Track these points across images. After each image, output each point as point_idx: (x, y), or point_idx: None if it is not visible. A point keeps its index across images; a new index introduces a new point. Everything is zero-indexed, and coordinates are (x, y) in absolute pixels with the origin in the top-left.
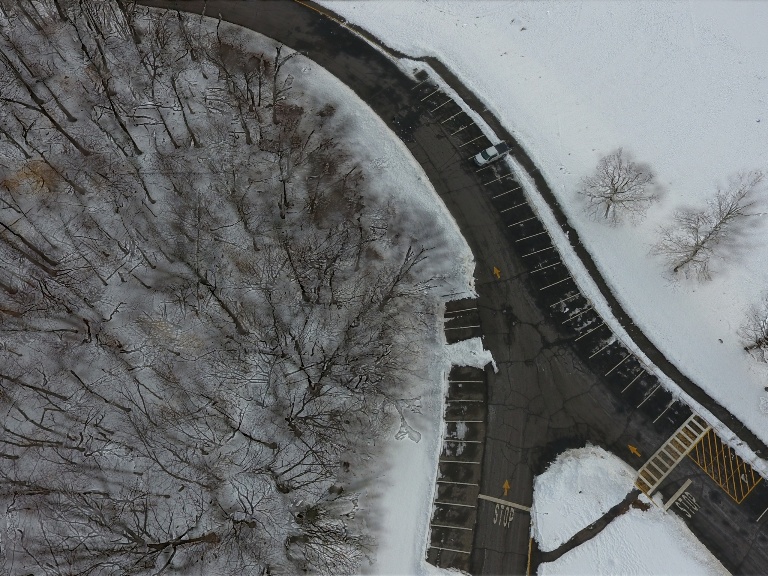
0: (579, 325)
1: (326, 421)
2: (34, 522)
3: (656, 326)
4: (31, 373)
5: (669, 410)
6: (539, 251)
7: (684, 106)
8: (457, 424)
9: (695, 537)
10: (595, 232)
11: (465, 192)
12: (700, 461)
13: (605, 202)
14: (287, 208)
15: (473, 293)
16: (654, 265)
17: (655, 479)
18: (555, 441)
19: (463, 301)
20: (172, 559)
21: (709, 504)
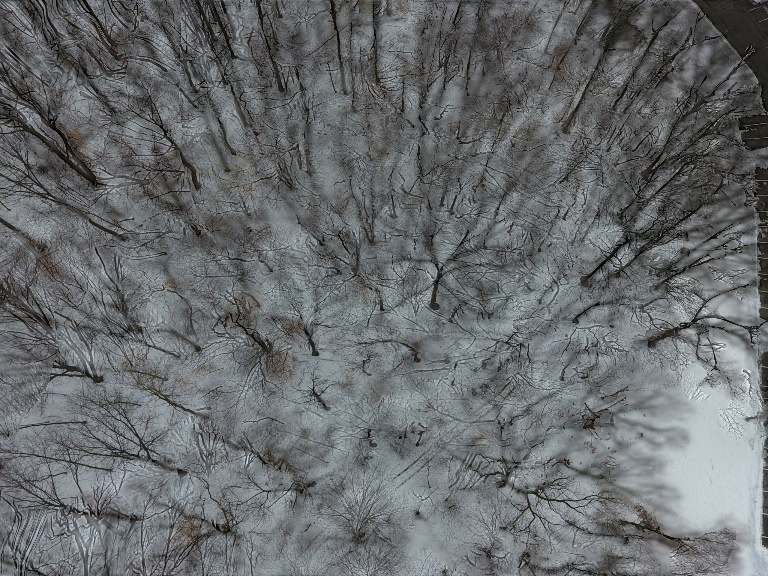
0: None
1: (667, 197)
2: None
3: None
4: (390, 153)
5: None
6: None
7: None
8: (767, 214)
9: None
10: None
11: (742, 27)
12: None
13: None
14: (578, 36)
15: (763, 110)
16: None
17: None
18: None
19: (754, 117)
20: (556, 296)
21: None
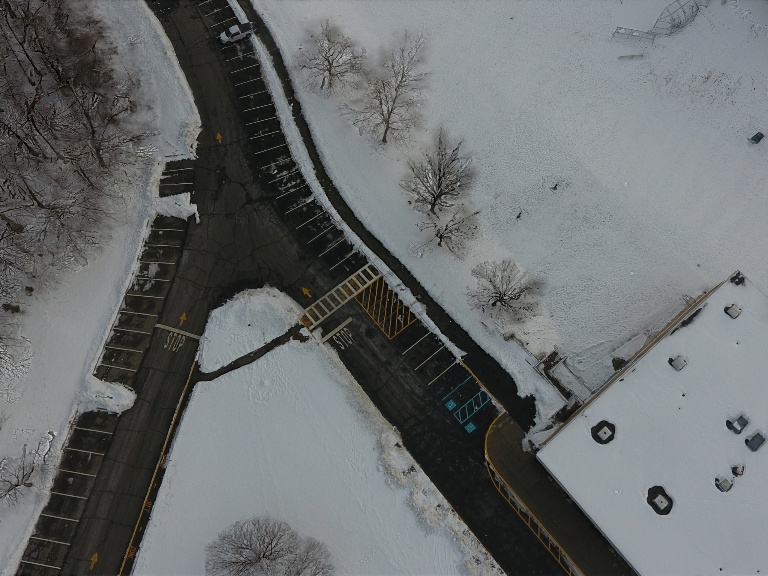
0: (283, 185)
1: (15, 250)
2: None
3: (353, 188)
4: None
5: (347, 259)
6: (262, 120)
7: (443, 1)
8: (150, 265)
9: (343, 365)
10: (317, 105)
11: (207, 67)
12: (364, 303)
13: (323, 75)
14: (38, 76)
15: (193, 155)
16: None
17: (319, 316)
18: (237, 282)
19: (183, 161)
20: None
21: (363, 339)
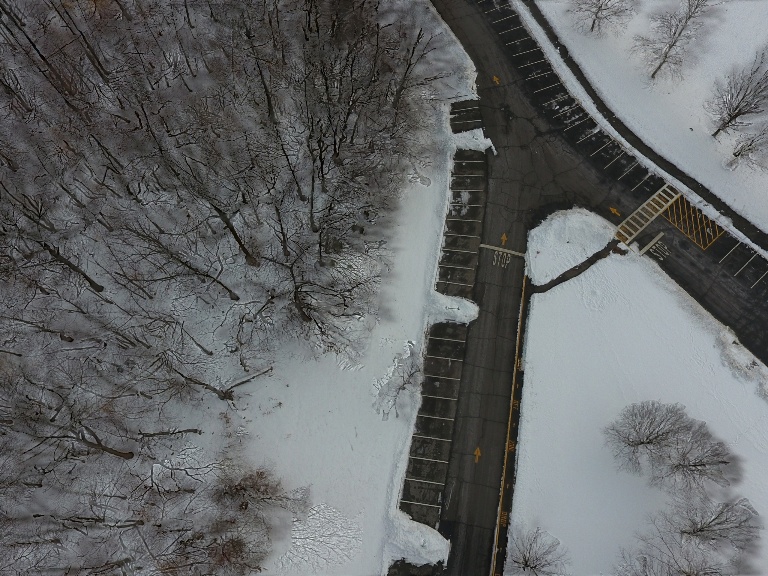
0: (568, 119)
1: (349, 178)
2: (102, 247)
3: (635, 118)
4: None
5: (645, 181)
6: (533, 63)
7: None
8: (461, 192)
9: (666, 274)
10: (583, 48)
11: (468, 19)
12: (672, 219)
13: (591, 18)
14: (310, 32)
15: (475, 96)
16: (634, 70)
17: (632, 232)
18: (546, 205)
19: (466, 102)
20: (220, 275)
21: (679, 250)
